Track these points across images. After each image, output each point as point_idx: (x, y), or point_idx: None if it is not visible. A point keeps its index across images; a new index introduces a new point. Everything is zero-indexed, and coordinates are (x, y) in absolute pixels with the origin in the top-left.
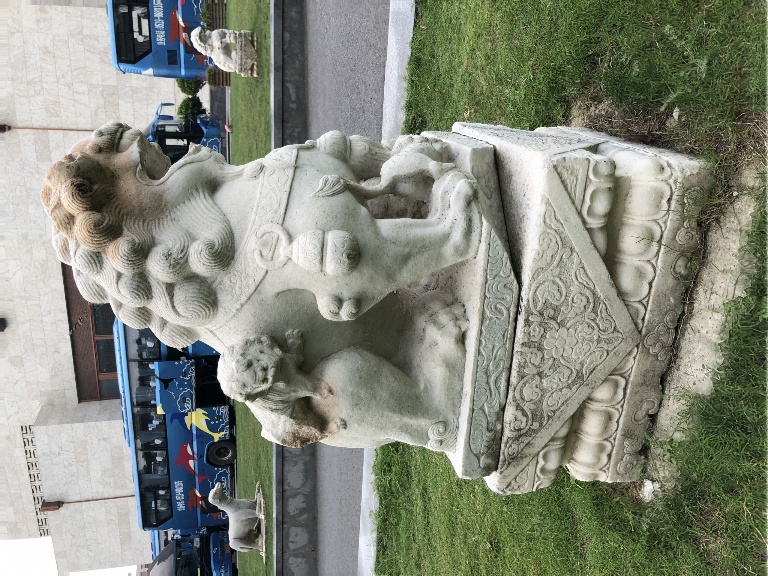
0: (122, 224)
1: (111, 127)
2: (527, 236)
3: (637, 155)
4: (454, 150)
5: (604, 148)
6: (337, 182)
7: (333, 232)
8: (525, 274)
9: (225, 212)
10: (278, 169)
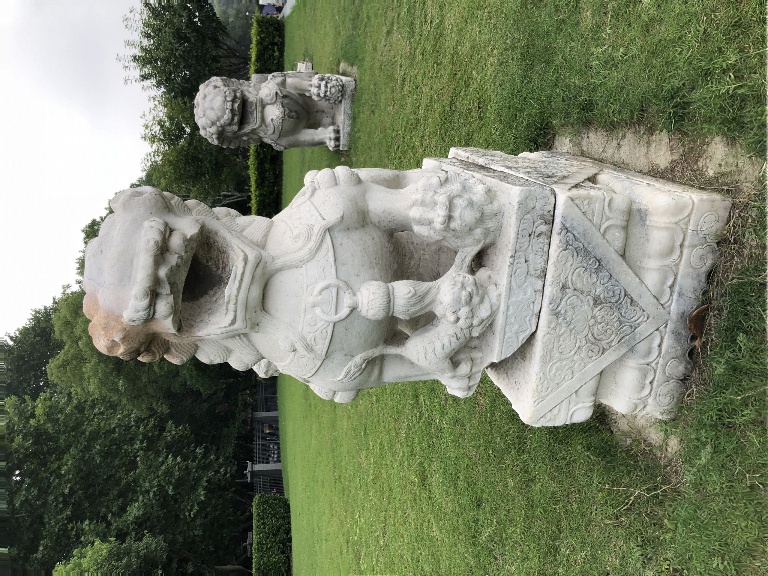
0: (169, 345)
1: (142, 316)
2: (501, 382)
3: (633, 391)
4: (495, 326)
5: (636, 350)
6: (358, 371)
7: (341, 396)
8: (490, 374)
9: (258, 349)
10: (308, 357)
